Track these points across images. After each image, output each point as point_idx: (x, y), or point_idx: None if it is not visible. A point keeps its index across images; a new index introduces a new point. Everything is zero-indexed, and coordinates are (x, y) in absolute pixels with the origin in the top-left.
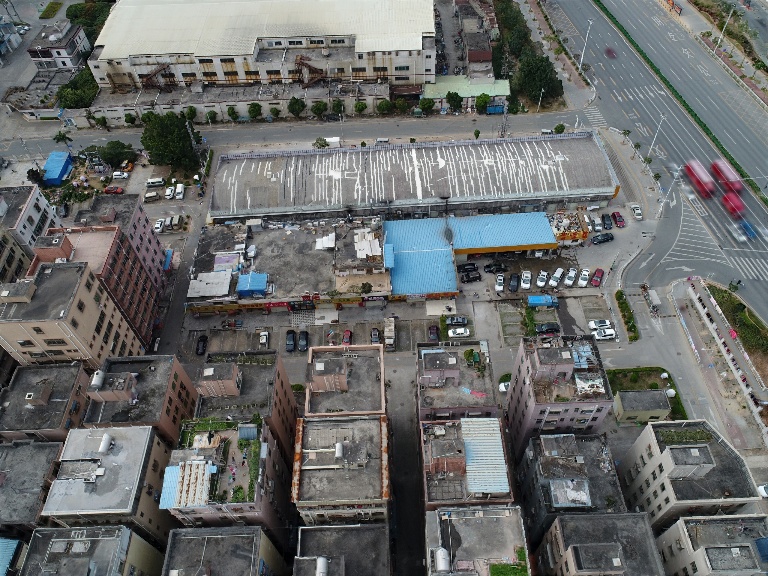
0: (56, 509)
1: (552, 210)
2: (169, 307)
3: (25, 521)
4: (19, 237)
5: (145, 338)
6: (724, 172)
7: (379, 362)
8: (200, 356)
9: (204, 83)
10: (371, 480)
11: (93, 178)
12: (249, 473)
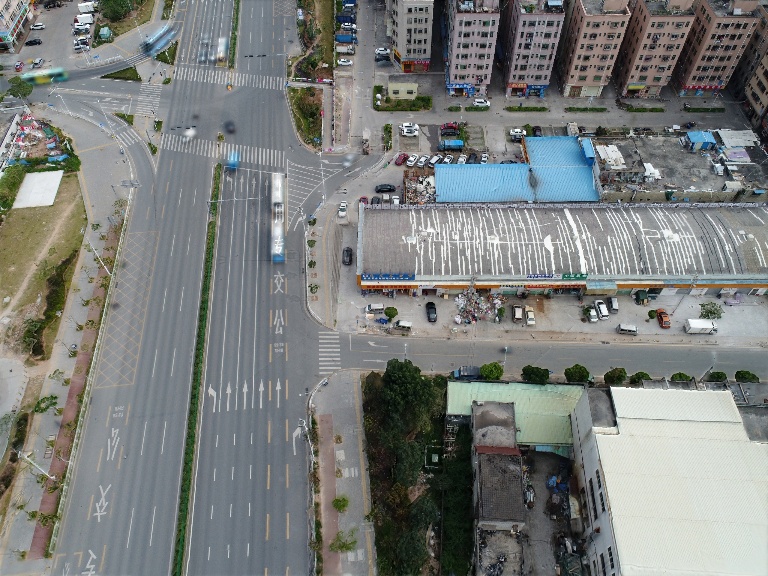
0: None
1: None
2: None
3: None
4: None
5: None
6: (227, 249)
7: None
8: None
9: None
10: None
11: None
12: None
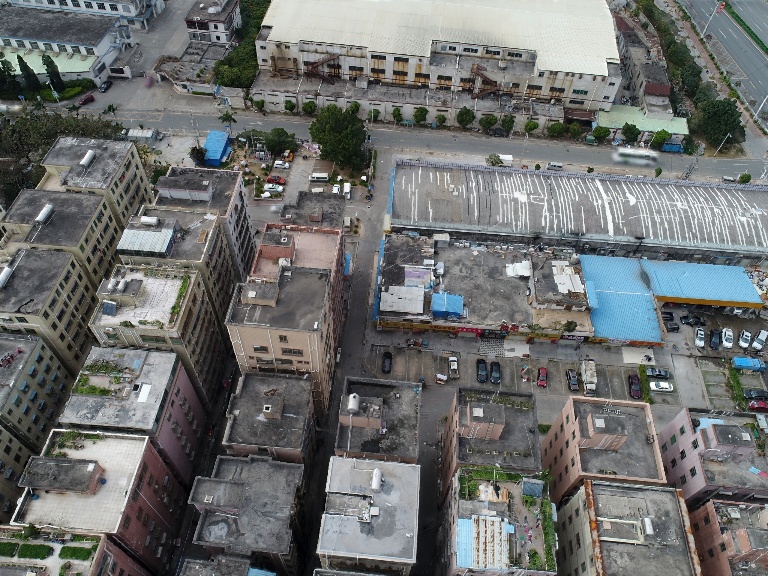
0: (333, 549)
1: (744, 265)
2: (347, 315)
3: (277, 551)
4: (226, 226)
5: (335, 348)
6: None
7: (648, 423)
8: (386, 374)
9: (369, 79)
10: (677, 563)
11: (253, 164)
12: (546, 537)
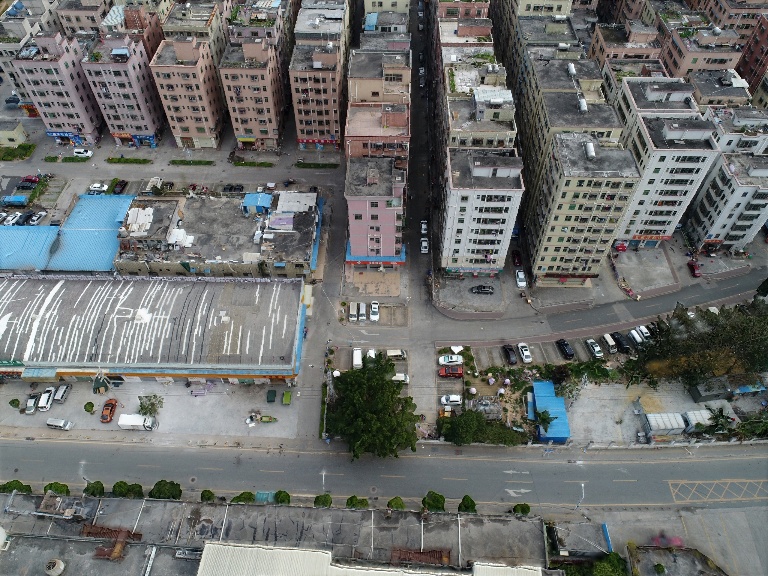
0: (337, 10)
1: None
2: (347, 225)
3: None
4: None
5: None
6: None
7: None
8: None
9: None
10: None
11: None
12: None
